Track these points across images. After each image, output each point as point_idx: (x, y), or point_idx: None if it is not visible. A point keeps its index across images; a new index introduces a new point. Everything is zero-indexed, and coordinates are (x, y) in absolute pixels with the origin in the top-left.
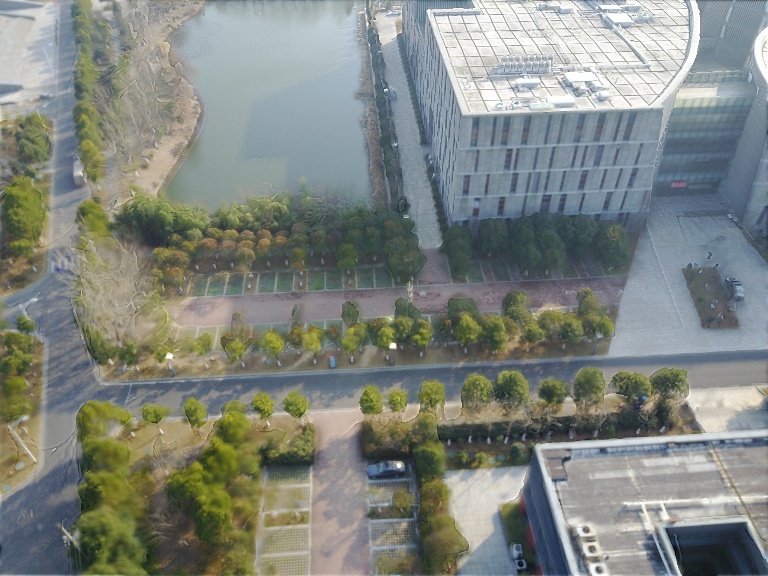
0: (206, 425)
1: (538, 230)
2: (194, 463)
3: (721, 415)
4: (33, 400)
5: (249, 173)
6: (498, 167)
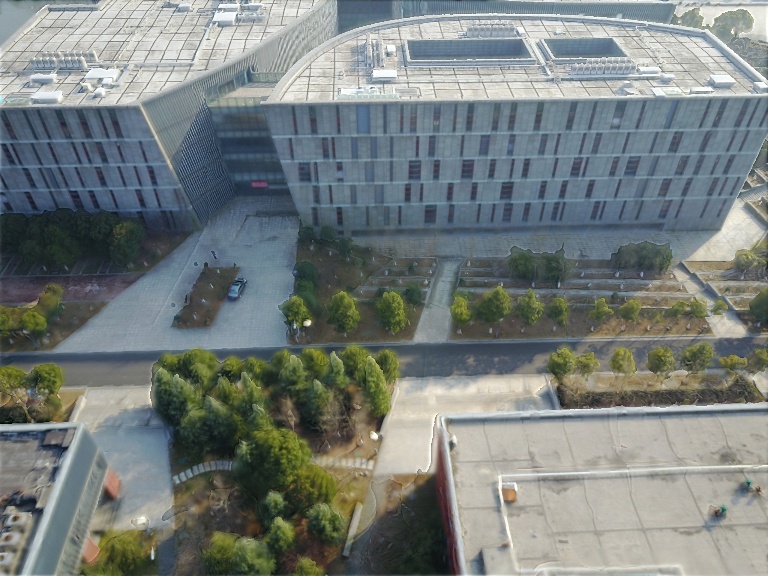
0: None
1: (48, 225)
2: None
3: (103, 413)
4: None
5: None
6: (2, 162)
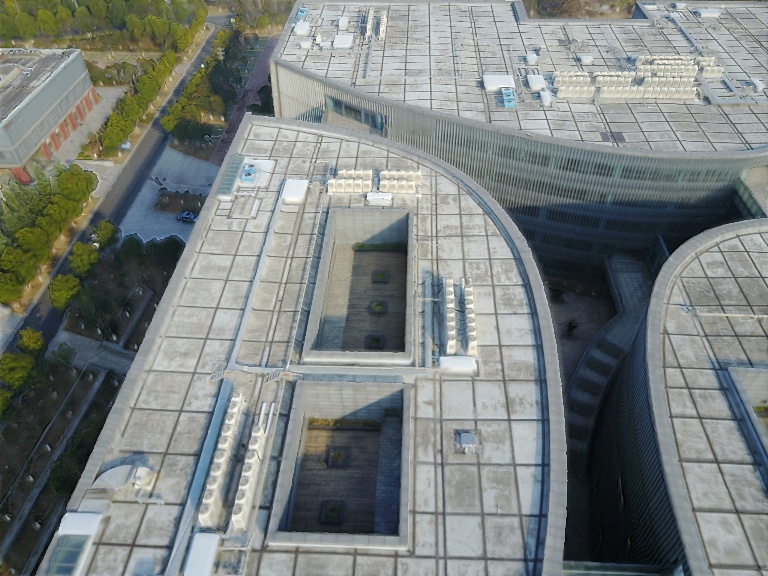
0: (200, 41)
1: None
2: None
3: None
4: (237, 10)
5: None
6: None
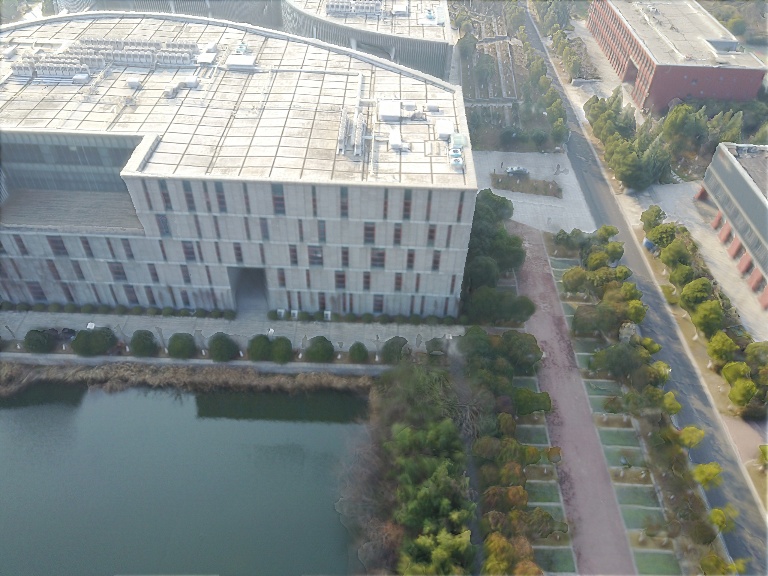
0: None
1: (493, 237)
2: None
3: None
4: None
5: None
6: None
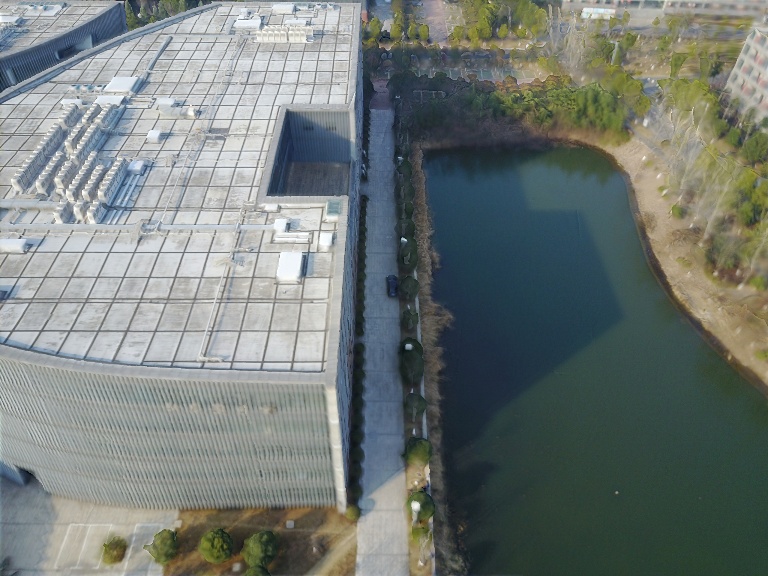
0: None
1: None
2: (492, 7)
3: None
4: None
5: (552, 196)
6: None
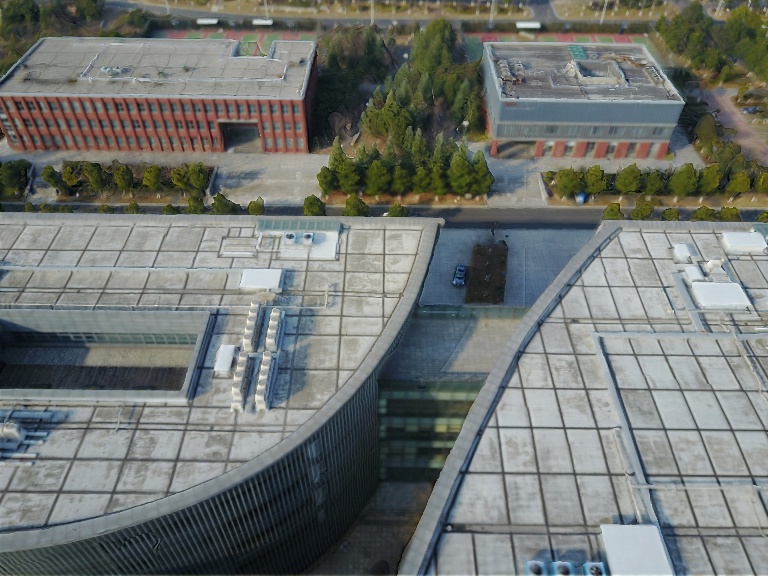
0: None
1: None
2: None
3: (525, 190)
4: None
5: None
6: None
